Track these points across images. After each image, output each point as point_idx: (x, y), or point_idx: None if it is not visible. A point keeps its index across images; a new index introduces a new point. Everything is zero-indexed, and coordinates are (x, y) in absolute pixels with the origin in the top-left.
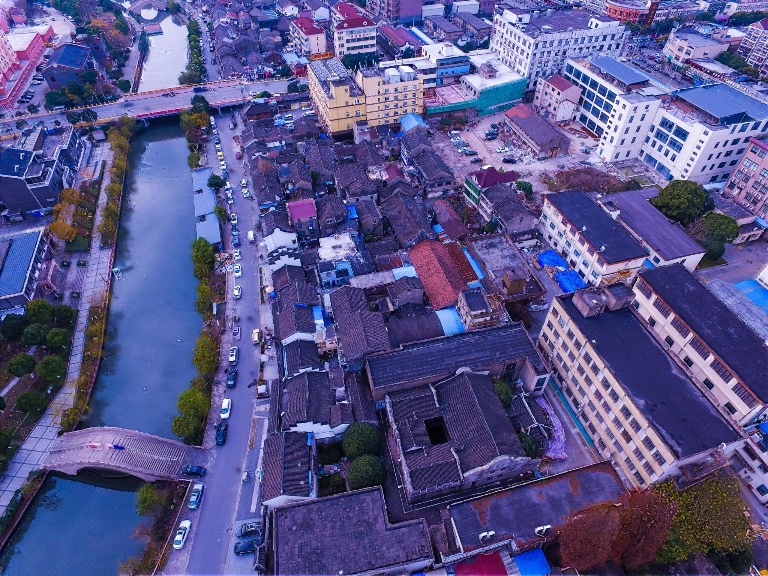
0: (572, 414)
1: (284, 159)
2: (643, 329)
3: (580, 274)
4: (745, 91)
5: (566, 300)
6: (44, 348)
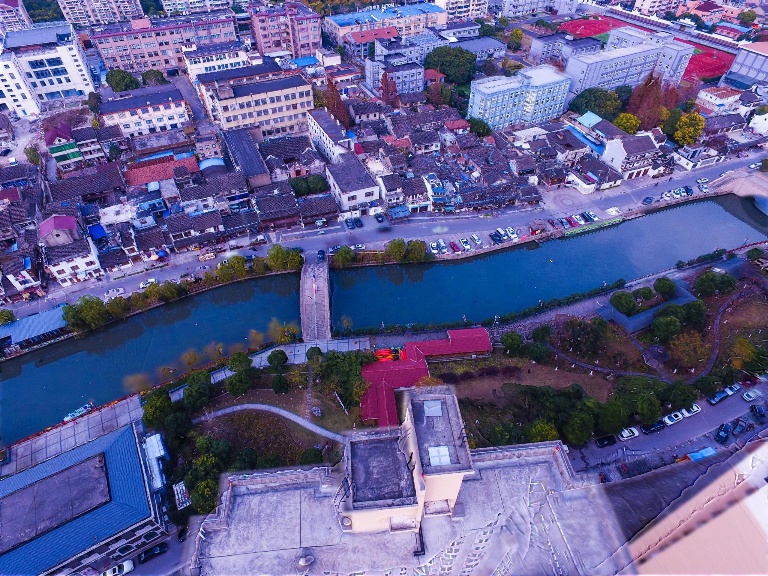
0: None
1: None
2: (242, 86)
3: (173, 128)
4: (28, 28)
5: None
6: (205, 406)
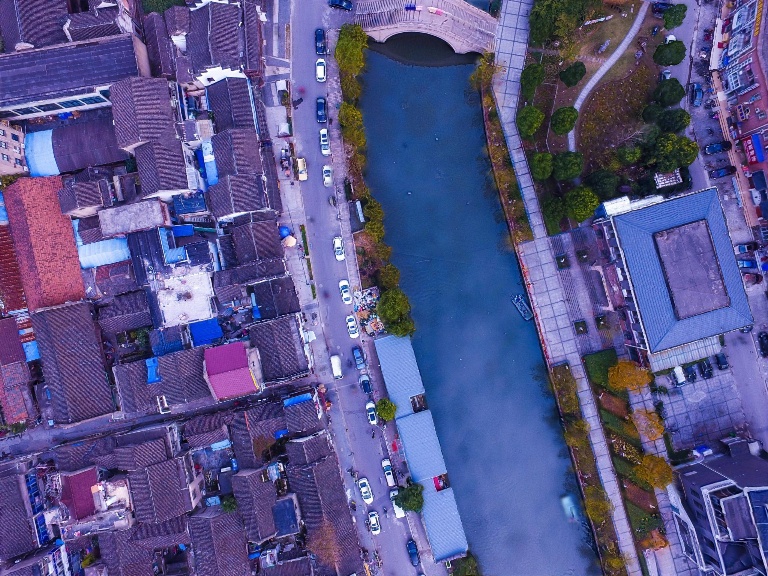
0: None
1: (295, 572)
2: None
3: None
4: None
5: None
6: None
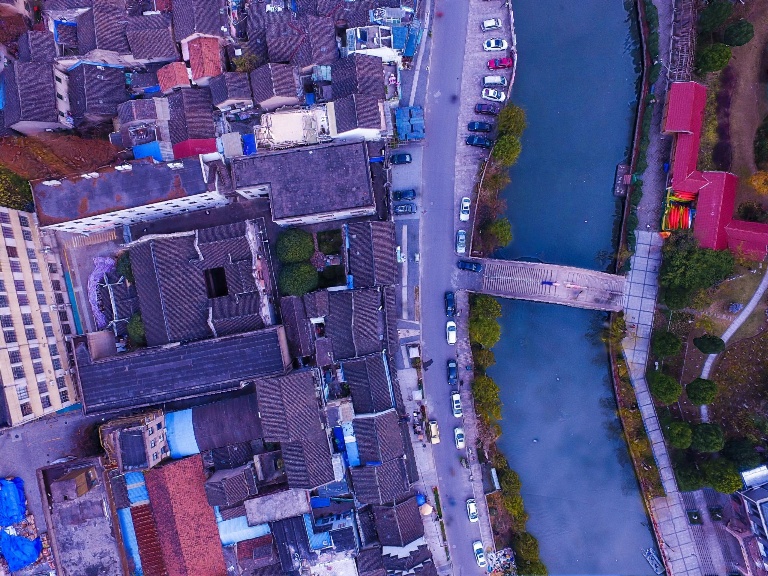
0: (75, 308)
1: None
2: None
3: None
4: None
5: (1, 423)
6: None
